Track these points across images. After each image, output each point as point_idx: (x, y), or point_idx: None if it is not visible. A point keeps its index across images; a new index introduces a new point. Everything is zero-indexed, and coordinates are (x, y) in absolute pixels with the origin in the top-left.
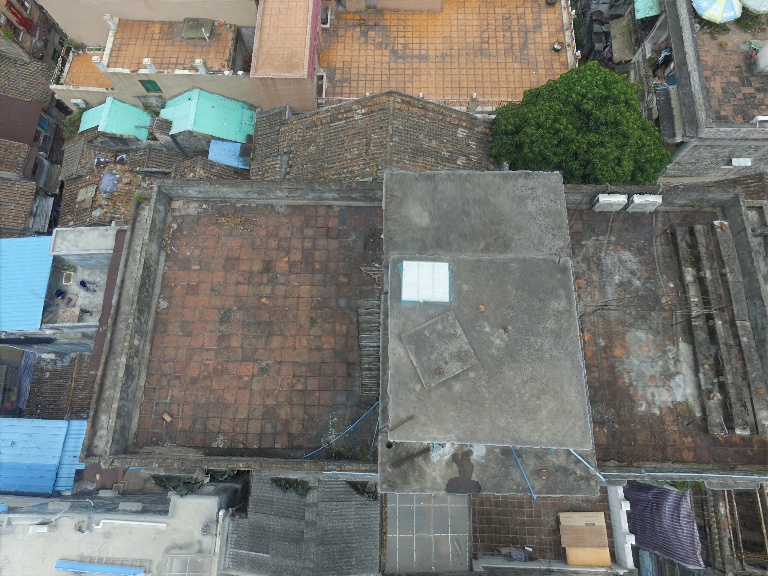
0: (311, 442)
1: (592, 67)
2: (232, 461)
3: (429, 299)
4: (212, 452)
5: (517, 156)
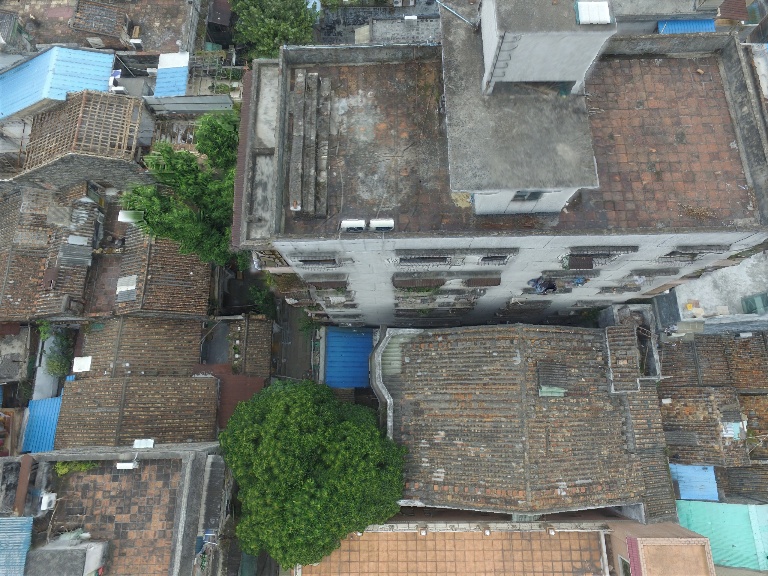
0: (595, 64)
1: (293, 553)
2: (650, 38)
3: (590, 3)
4: (661, 56)
5: (381, 441)
